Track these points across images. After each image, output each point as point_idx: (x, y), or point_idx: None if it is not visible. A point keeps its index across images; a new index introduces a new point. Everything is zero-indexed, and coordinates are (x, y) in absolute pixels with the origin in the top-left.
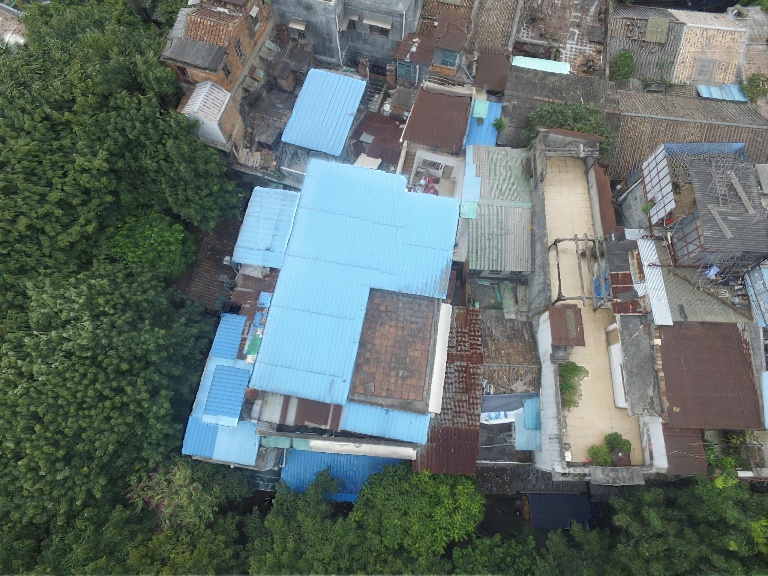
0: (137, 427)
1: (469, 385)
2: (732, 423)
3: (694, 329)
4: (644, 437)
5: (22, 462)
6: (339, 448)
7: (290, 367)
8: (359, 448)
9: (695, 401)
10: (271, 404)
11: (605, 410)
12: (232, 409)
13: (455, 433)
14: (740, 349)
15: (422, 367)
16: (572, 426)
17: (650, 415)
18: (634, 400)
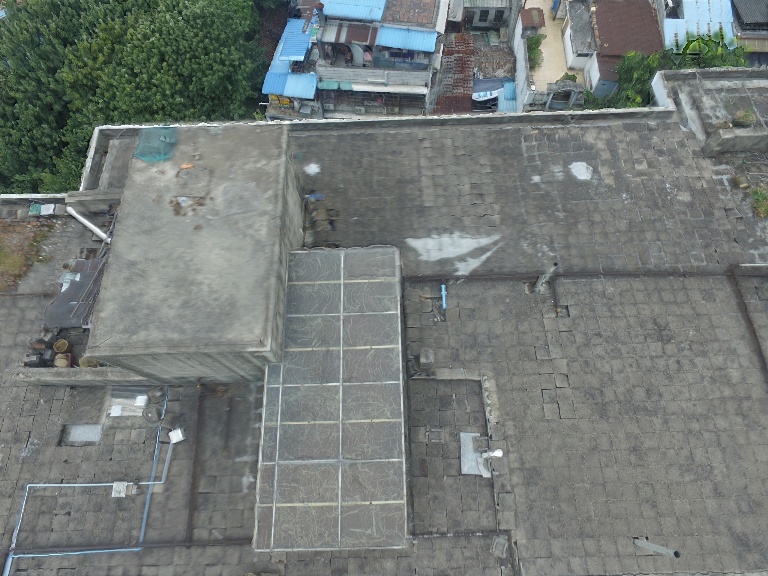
0: (228, 85)
1: (464, 68)
2: (644, 52)
3: (619, 2)
4: (587, 81)
5: (155, 80)
6: (372, 88)
7: (343, 3)
8: (387, 87)
9: (619, 41)
10: (329, 31)
11: (560, 72)
12: (300, 52)
13: (454, 100)
14: (650, 13)
15: (431, 8)
16: (537, 80)
17: (588, 51)
18: (577, 44)
